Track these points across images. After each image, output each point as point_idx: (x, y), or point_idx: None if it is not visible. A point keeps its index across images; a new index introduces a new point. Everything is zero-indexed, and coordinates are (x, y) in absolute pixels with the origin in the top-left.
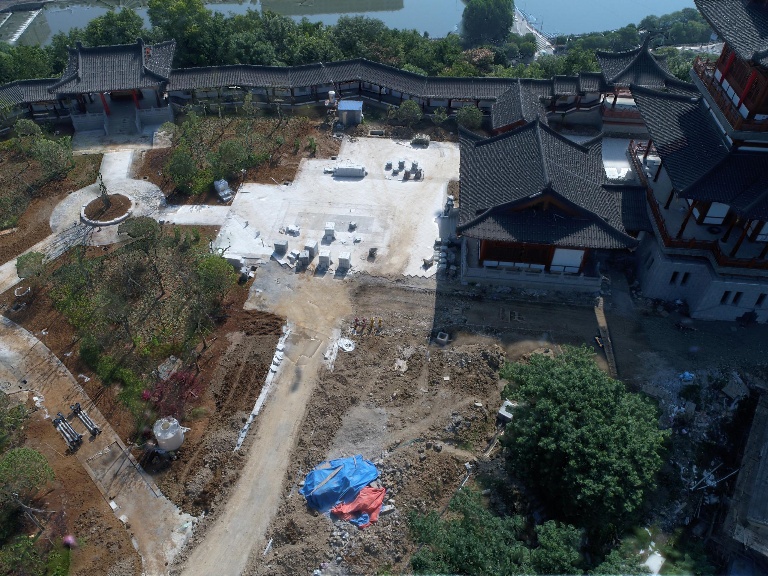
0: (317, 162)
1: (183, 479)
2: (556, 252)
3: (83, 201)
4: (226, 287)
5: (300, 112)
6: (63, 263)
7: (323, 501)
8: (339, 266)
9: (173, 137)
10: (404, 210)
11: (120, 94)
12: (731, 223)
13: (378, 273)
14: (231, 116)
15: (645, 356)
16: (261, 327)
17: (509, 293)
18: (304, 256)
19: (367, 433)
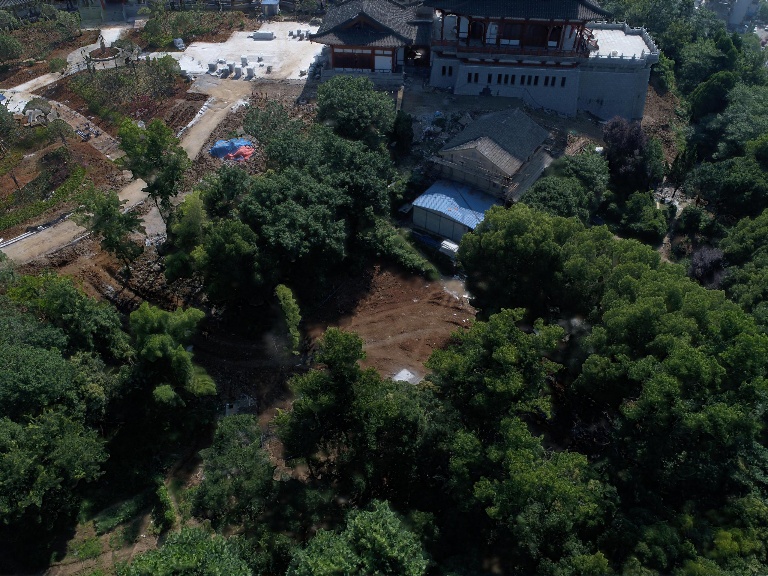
0: (244, 33)
1: None
2: (376, 59)
3: None
4: (175, 73)
5: (237, 10)
6: (76, 75)
7: (220, 153)
8: (248, 75)
9: None
10: (295, 53)
11: None
12: (474, 36)
13: (271, 78)
14: None
15: (419, 108)
16: (196, 97)
17: None
18: (226, 68)
19: None
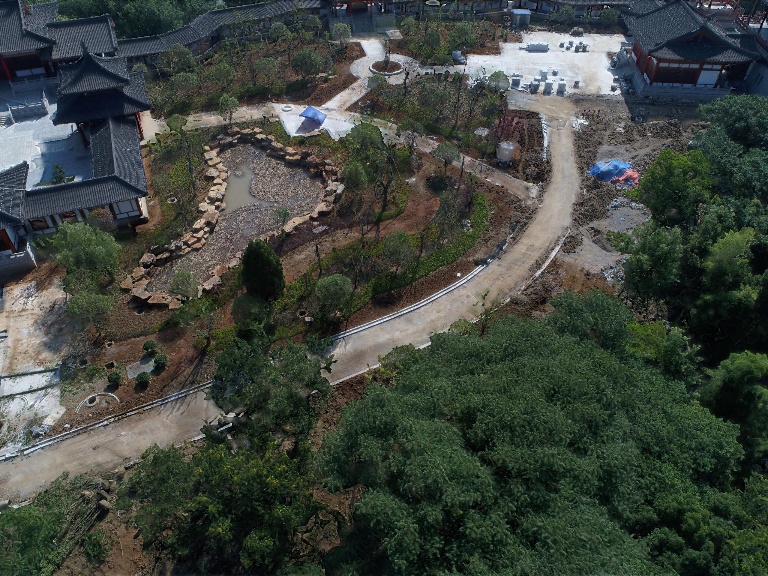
0: (511, 44)
1: (521, 171)
2: (701, 73)
3: (366, 64)
4: (506, 90)
5: None
6: (380, 91)
7: (606, 176)
8: (558, 90)
9: (401, 33)
10: (584, 66)
11: (353, 8)
12: None
13: (584, 93)
14: (436, 20)
15: None
16: (527, 115)
17: (671, 101)
18: (536, 84)
19: (615, 154)
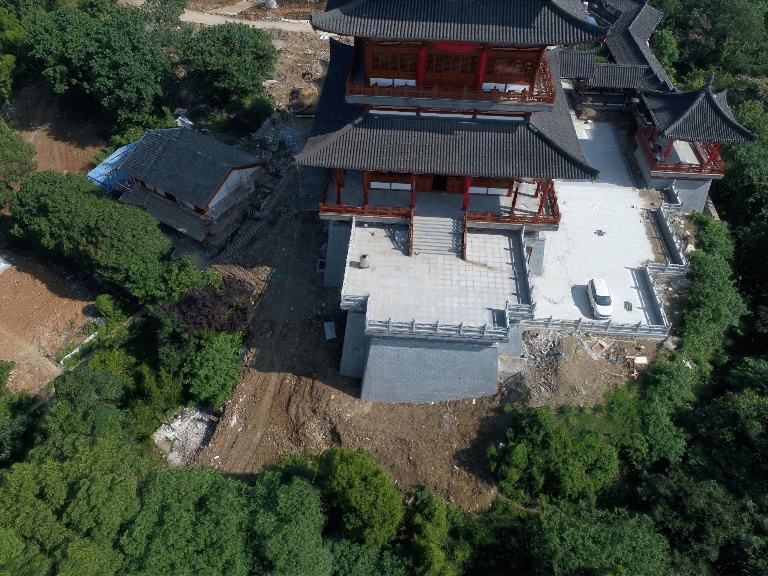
0: None
1: None
2: None
3: None
4: None
5: None
6: None
7: None
8: None
9: None
10: None
11: None
12: None
13: None
14: None
15: None
16: None
17: None
18: None
19: None
